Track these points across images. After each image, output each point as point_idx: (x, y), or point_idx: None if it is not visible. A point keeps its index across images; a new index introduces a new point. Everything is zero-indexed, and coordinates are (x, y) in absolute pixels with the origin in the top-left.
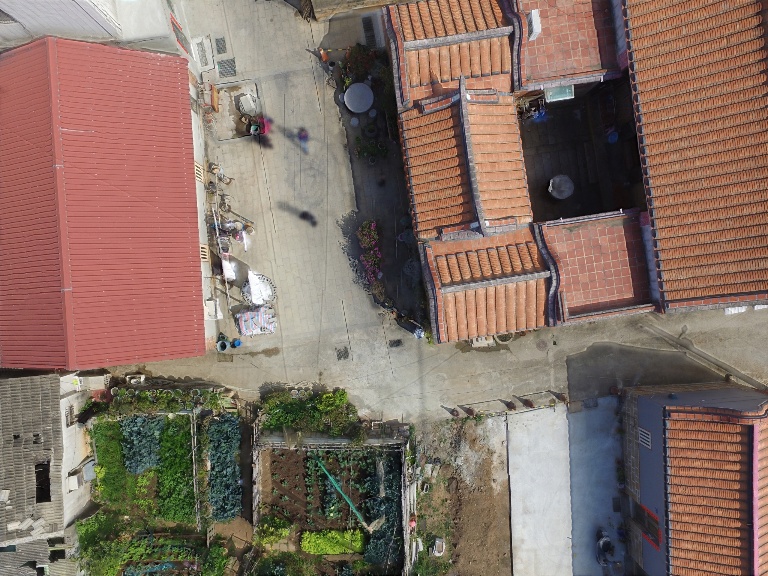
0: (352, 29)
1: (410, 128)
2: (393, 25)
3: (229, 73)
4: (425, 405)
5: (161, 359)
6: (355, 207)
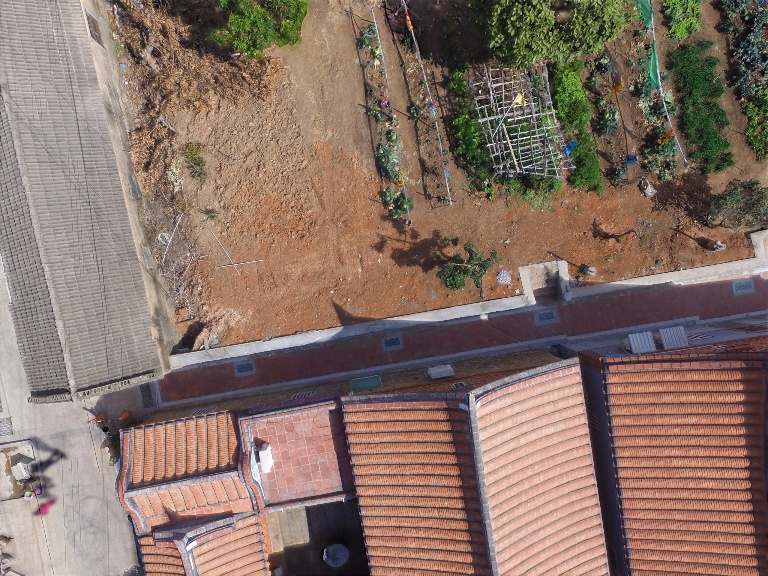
0: (128, 388)
1: (149, 553)
2: (123, 461)
3: (6, 432)
4: None
5: None
6: (137, 562)
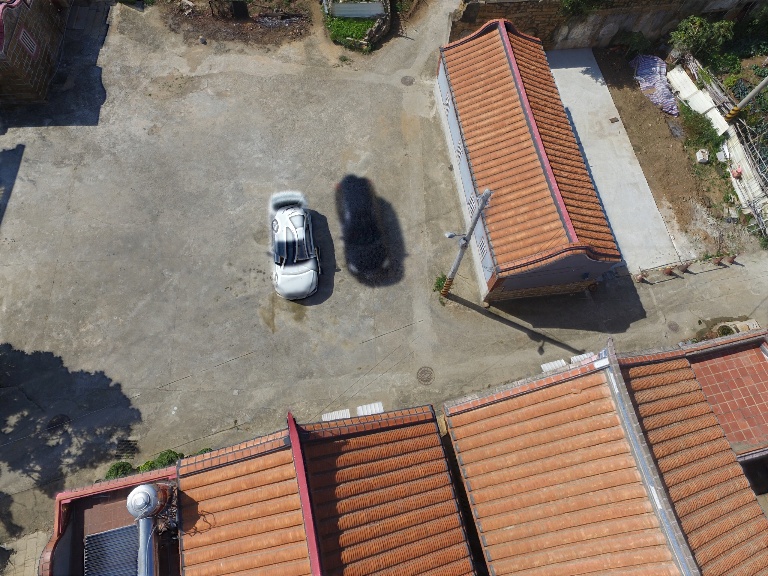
0: None
1: None
2: None
3: None
4: (759, 266)
5: None
6: None
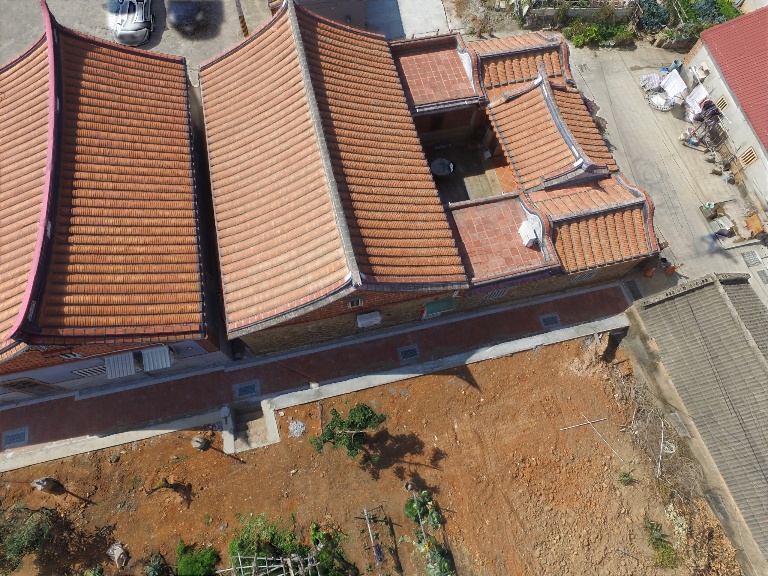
0: None
1: None
2: None
3: (748, 255)
4: None
5: (735, 19)
6: None
